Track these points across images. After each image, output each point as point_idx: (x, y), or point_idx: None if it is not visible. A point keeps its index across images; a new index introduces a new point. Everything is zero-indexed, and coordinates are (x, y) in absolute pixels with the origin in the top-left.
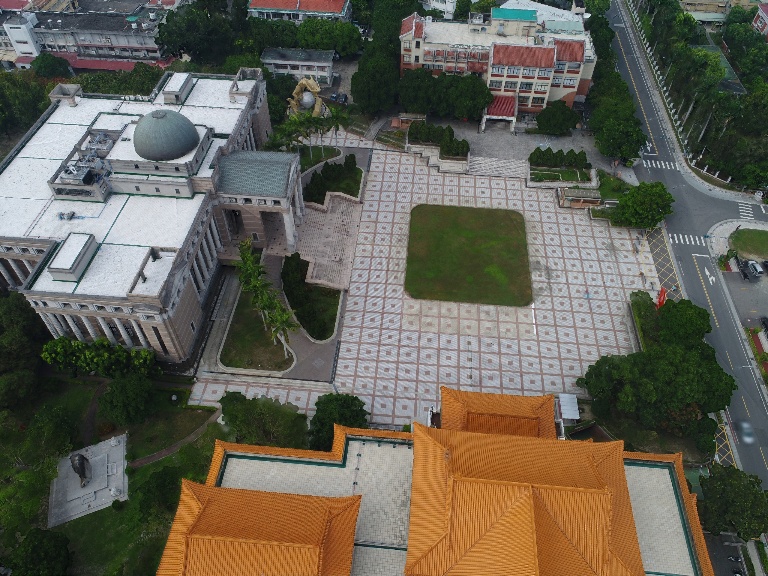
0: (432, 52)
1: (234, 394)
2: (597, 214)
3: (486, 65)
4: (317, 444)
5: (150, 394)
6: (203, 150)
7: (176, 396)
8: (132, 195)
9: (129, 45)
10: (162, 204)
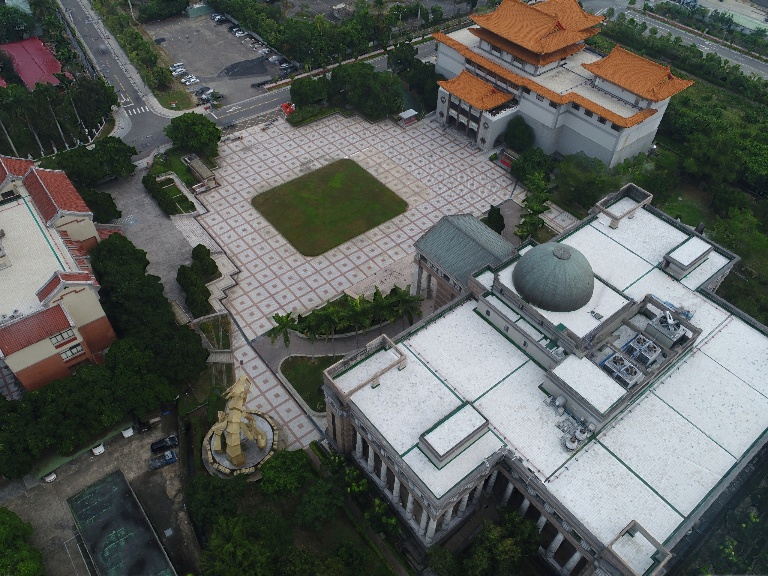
0: None
1: (589, 191)
2: None
3: None
4: None
5: None
6: None
7: None
8: None
9: None
10: None
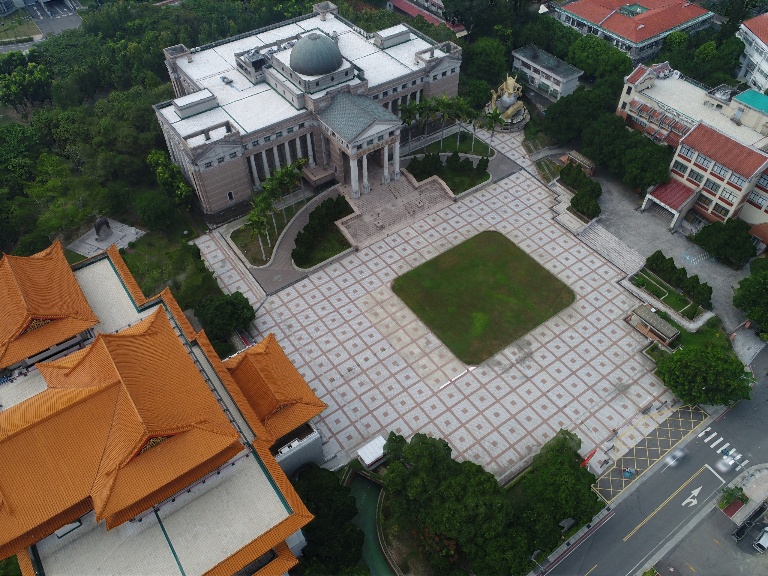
0: (639, 104)
1: (191, 246)
2: (653, 352)
3: None
4: (198, 314)
5: (165, 215)
6: (333, 80)
7: (188, 232)
8: (273, 89)
9: (438, 2)
10: (279, 103)
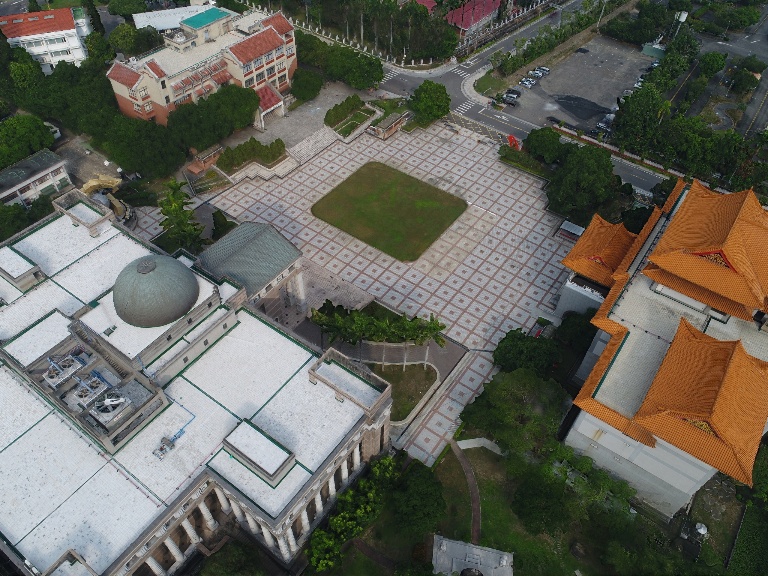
0: (179, 84)
1: (474, 405)
2: (409, 128)
3: (226, 72)
4: (541, 375)
5: None
6: None
7: None
8: (182, 373)
9: None
10: (225, 350)
